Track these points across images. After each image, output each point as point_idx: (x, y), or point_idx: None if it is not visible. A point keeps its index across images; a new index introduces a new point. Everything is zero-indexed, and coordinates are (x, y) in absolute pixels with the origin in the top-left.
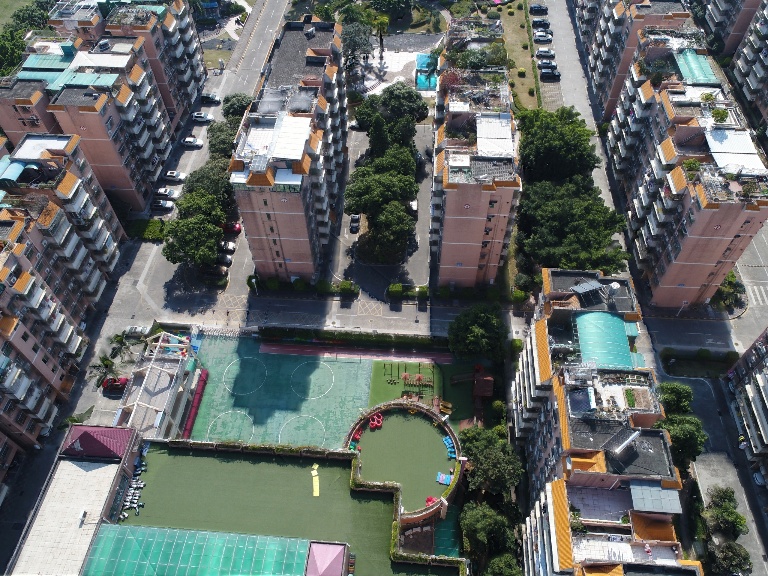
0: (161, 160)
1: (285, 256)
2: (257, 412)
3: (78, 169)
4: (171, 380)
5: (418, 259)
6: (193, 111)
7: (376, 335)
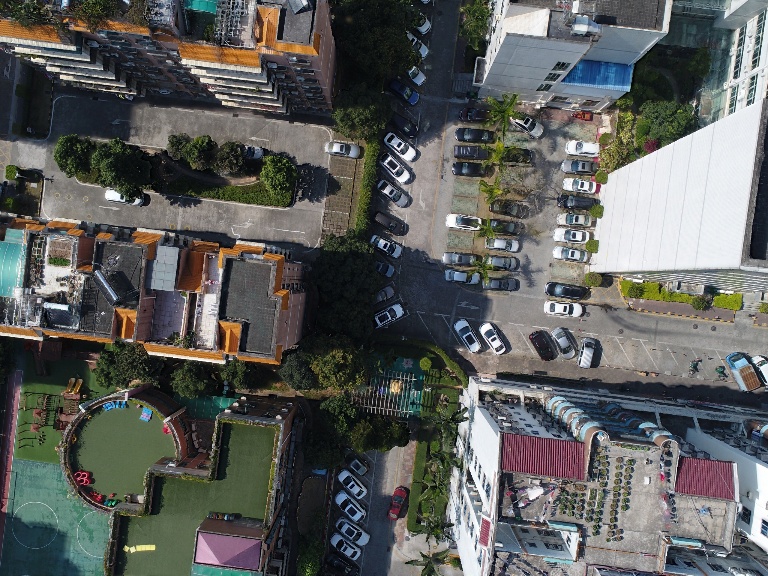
0: None
1: None
2: None
3: None
4: None
5: None
6: None
7: None
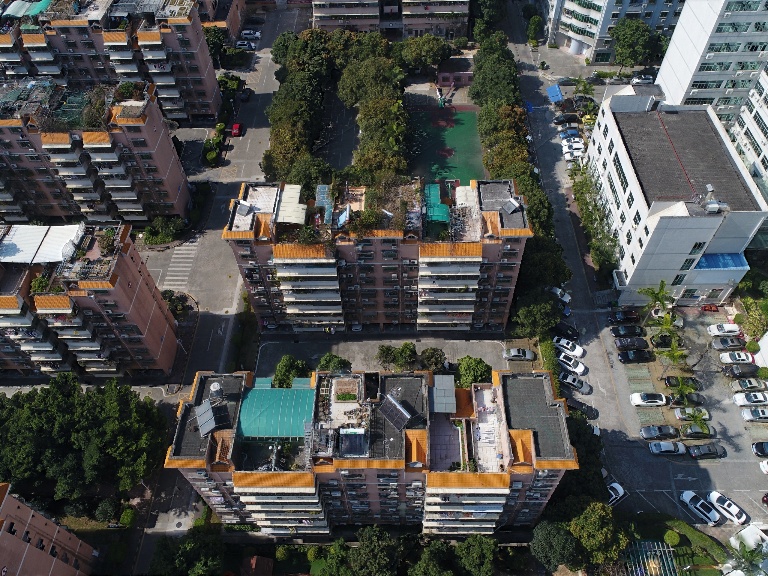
0: None
1: None
2: None
3: None
4: None
5: None
6: None
7: None
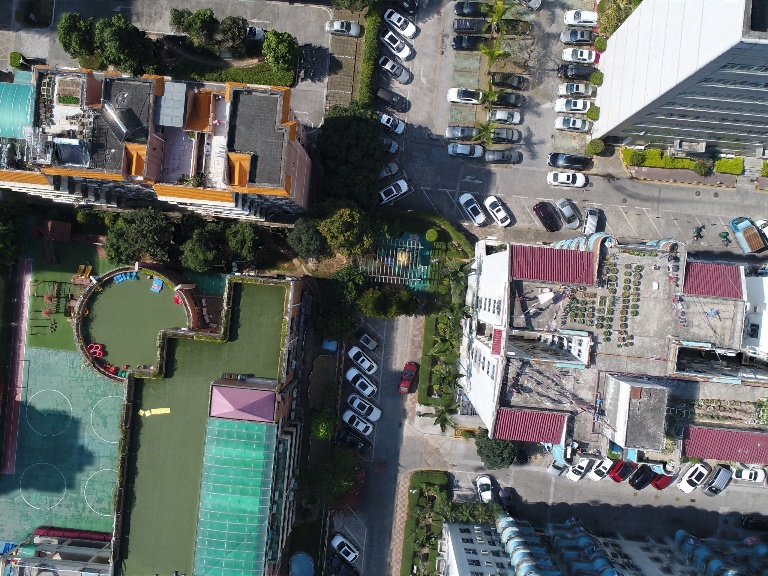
0: None
1: None
2: (86, 468)
3: None
4: (45, 571)
5: None
6: None
7: None
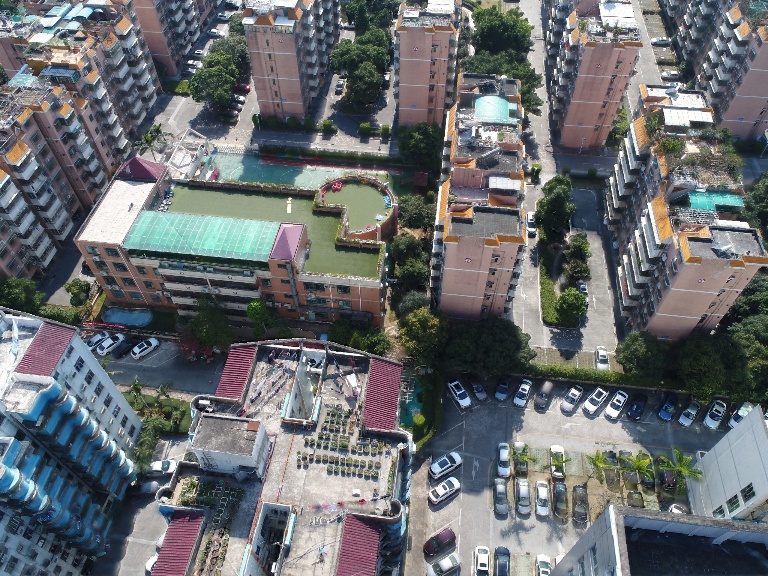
0: (191, 39)
1: (282, 96)
2: None
3: (131, 19)
4: (192, 158)
5: (386, 112)
6: (218, 13)
7: (346, 153)
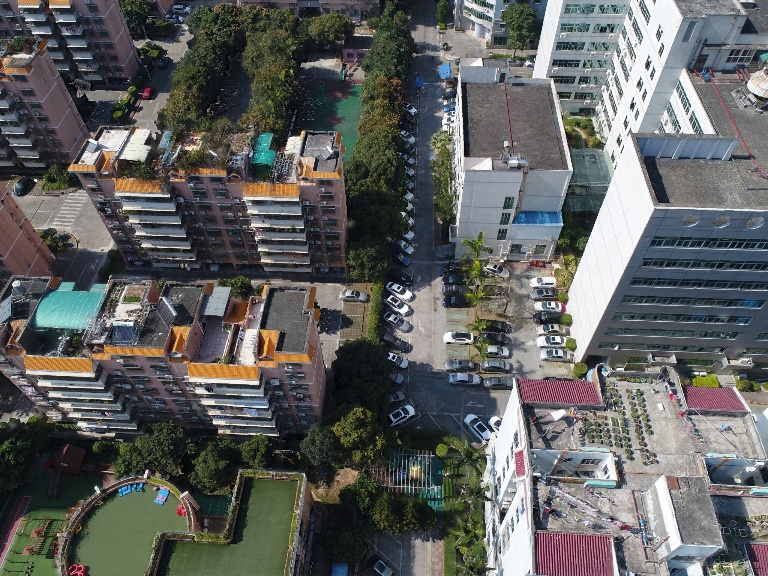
0: None
1: None
2: None
3: None
4: None
5: None
6: None
7: None
